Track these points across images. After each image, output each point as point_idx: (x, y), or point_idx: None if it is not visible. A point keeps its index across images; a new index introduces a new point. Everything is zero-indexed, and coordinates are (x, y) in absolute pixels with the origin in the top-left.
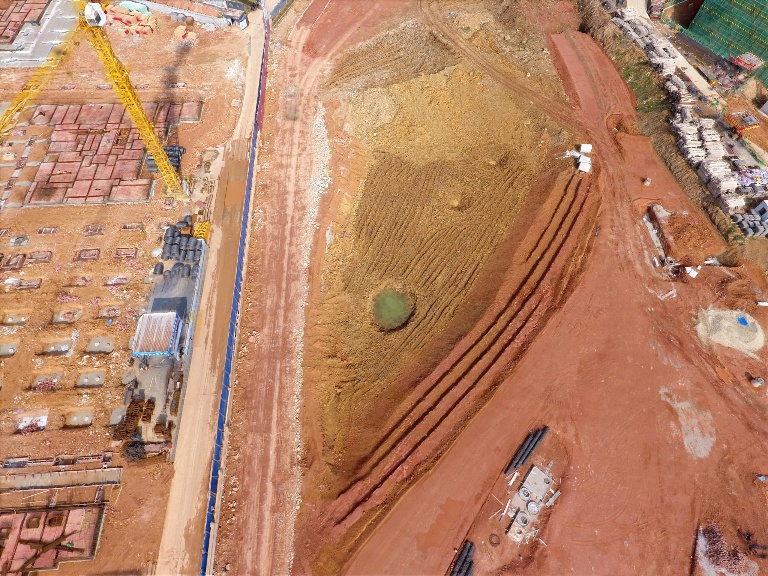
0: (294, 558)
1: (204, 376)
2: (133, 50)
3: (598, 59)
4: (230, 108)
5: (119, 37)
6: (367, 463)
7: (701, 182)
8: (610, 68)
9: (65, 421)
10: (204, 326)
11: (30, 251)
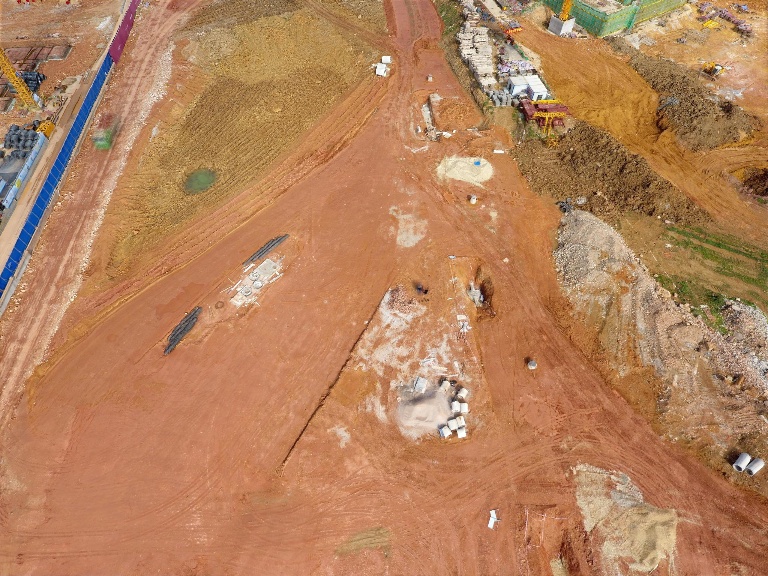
0: (57, 330)
1: (20, 223)
2: (21, 14)
3: (422, 3)
4: (94, 49)
5: (12, 6)
6: (137, 270)
7: (470, 73)
8: (430, 8)
9: None
10: (30, 191)
11: None
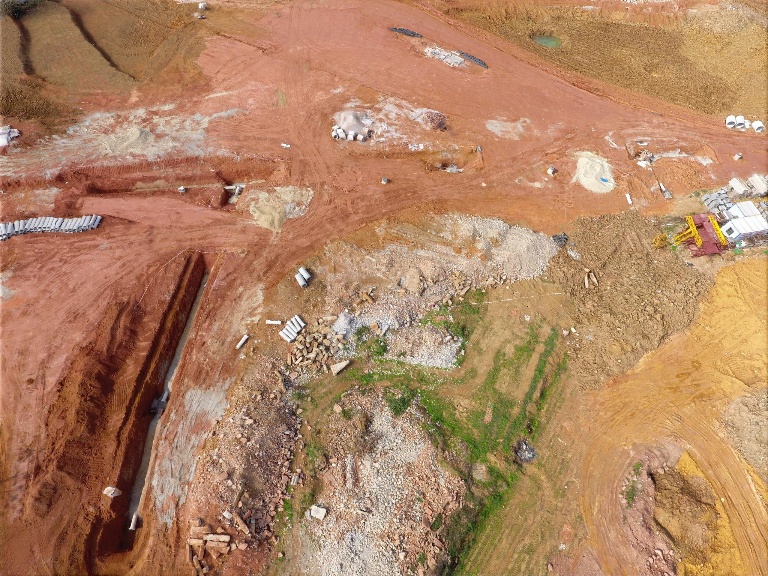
0: None
1: None
2: None
3: None
4: None
5: None
6: None
7: None
8: None
9: None
10: None
11: None
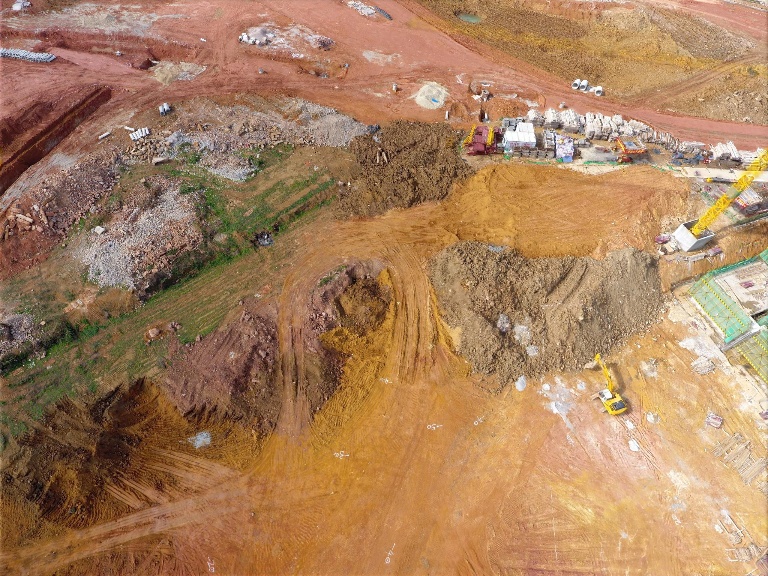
0: None
1: None
2: None
3: (745, 147)
4: None
5: None
6: None
7: None
8: None
9: None
10: None
11: None
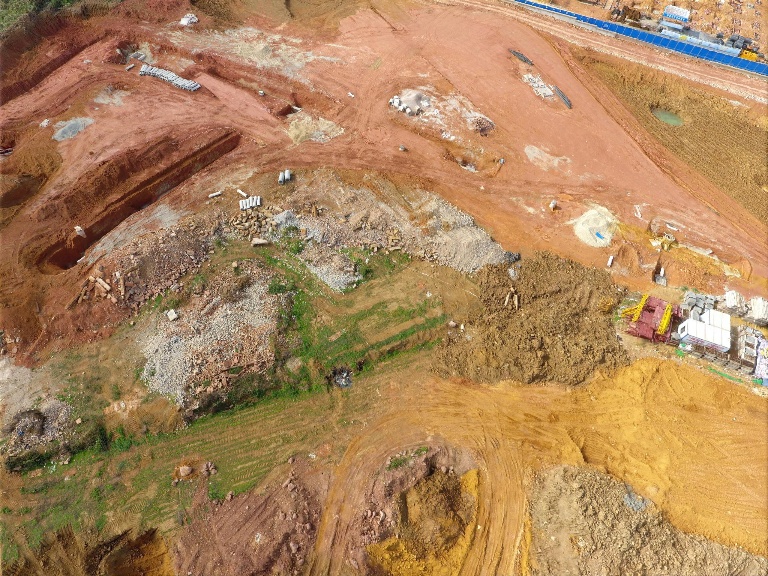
0: None
1: None
2: None
3: None
4: None
5: None
6: None
7: None
8: None
9: (637, 5)
10: None
11: (743, 8)
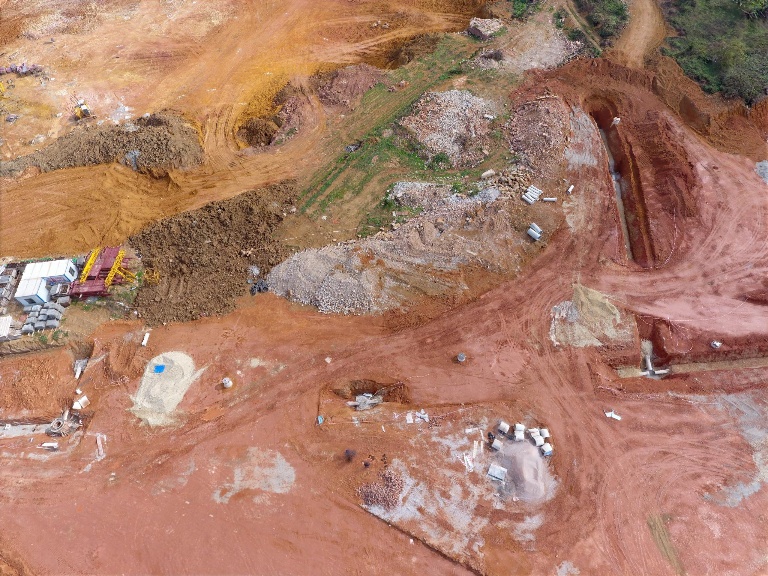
0: None
1: None
2: None
3: None
4: None
5: None
6: None
7: None
8: None
9: None
10: None
11: None
